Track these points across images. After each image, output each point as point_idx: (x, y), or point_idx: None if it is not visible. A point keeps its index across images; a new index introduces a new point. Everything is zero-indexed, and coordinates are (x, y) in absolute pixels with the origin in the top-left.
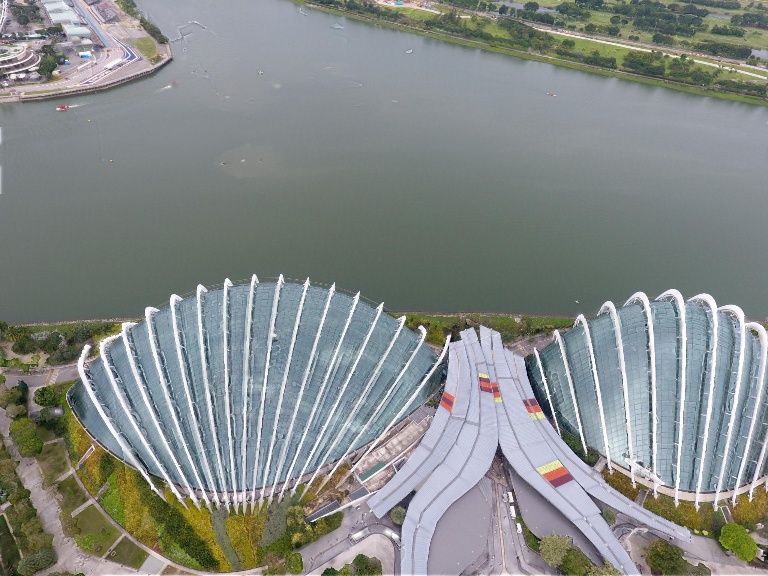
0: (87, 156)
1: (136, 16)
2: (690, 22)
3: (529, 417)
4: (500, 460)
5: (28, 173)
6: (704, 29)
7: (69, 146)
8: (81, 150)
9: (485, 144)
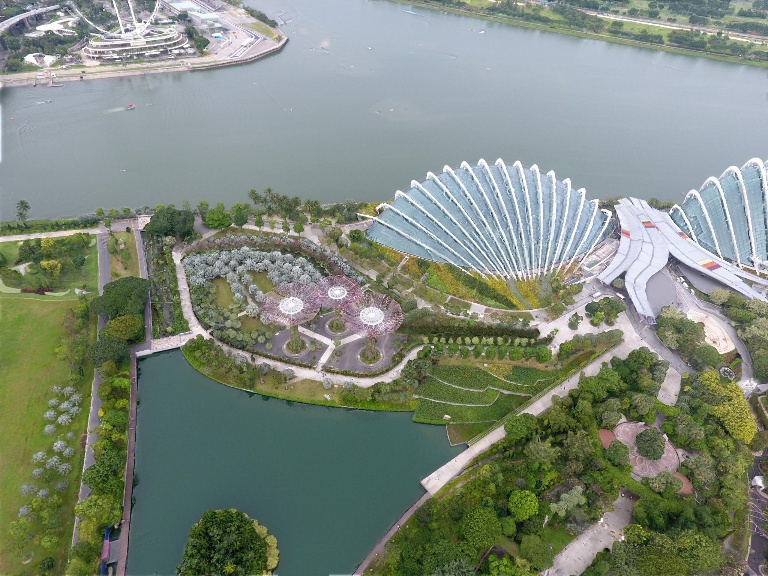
0: (271, 107)
1: (238, 6)
2: (718, 6)
3: (683, 239)
4: (669, 263)
5: (234, 118)
6: (731, 12)
7: (252, 100)
8: (263, 103)
9: (575, 98)
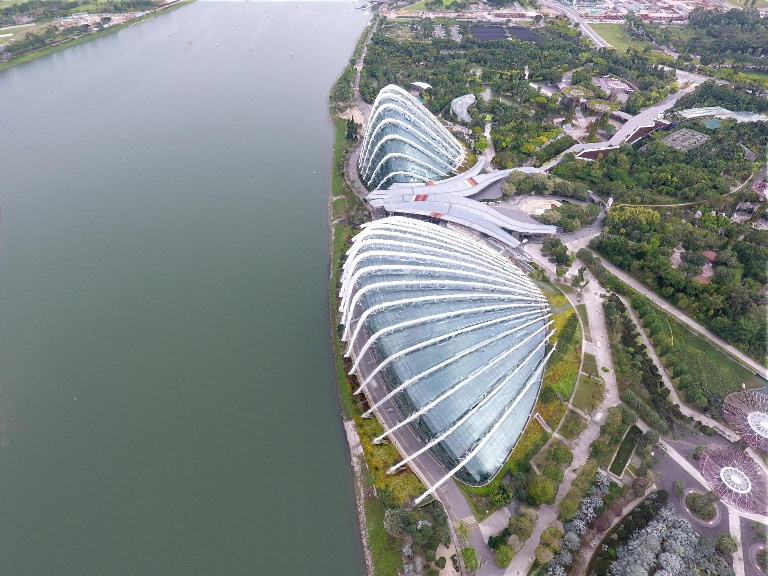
0: None
1: None
2: None
3: (440, 185)
4: None
5: None
6: None
7: None
8: None
9: (36, 194)
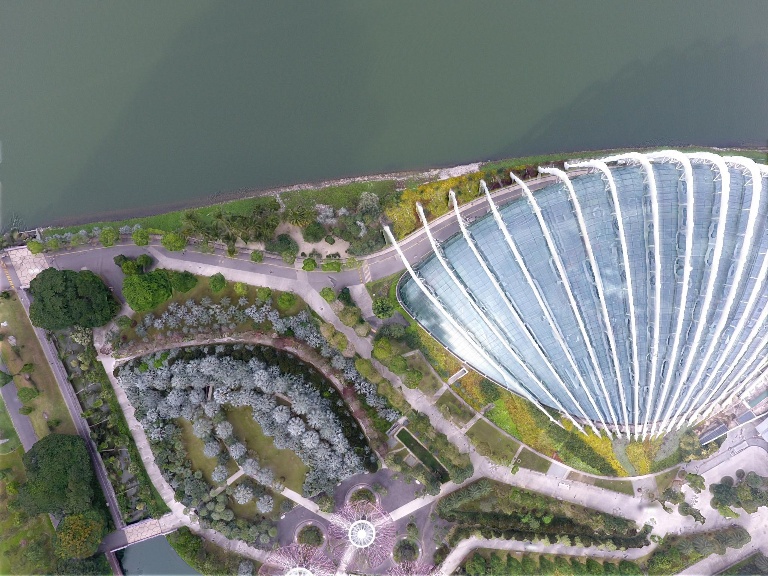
0: None
1: None
2: None
3: None
4: None
5: None
6: None
7: None
8: None
9: None
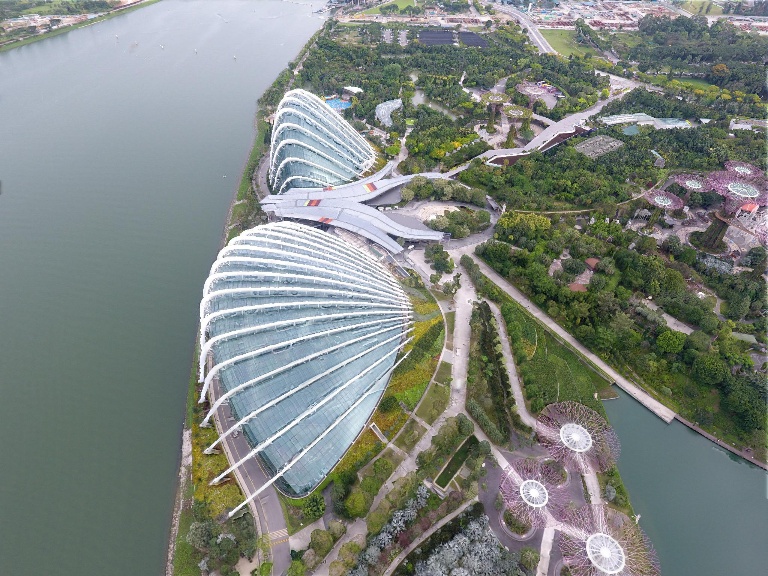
0: None
1: None
2: None
3: (337, 190)
4: None
5: None
6: None
7: None
8: None
9: None
